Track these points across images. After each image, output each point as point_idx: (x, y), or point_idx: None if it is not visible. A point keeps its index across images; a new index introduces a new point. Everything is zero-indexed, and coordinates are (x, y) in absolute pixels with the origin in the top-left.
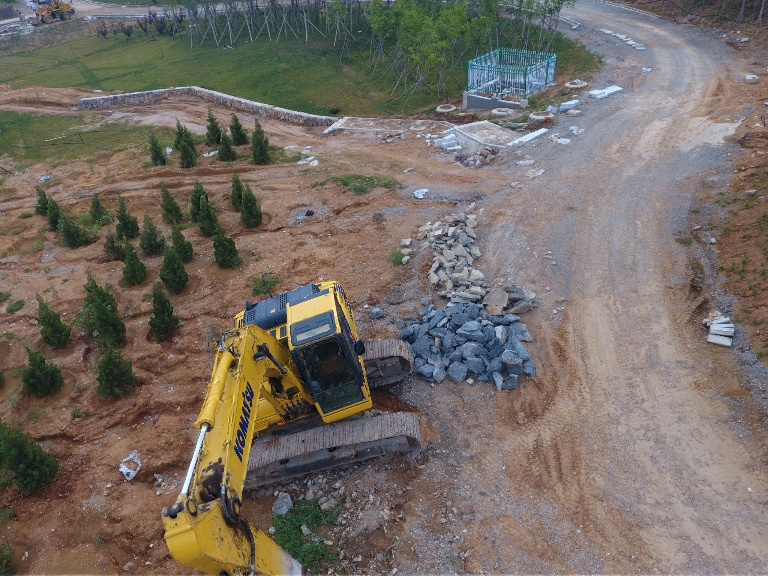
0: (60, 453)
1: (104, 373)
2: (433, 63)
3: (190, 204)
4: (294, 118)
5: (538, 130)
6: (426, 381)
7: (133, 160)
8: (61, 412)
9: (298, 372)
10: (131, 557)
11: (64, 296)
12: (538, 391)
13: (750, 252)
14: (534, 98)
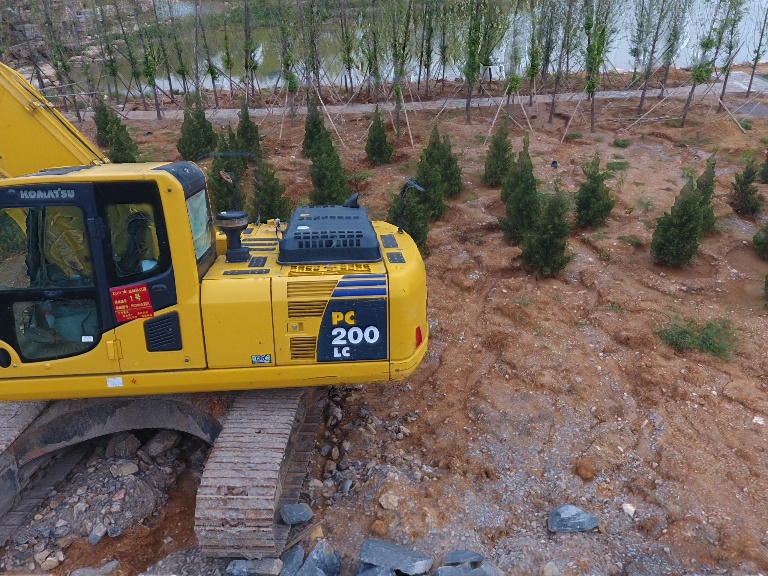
0: None
1: None
2: None
3: None
4: None
5: None
6: None
7: None
8: None
9: None
10: None
11: (628, 193)
12: None
13: None
14: None
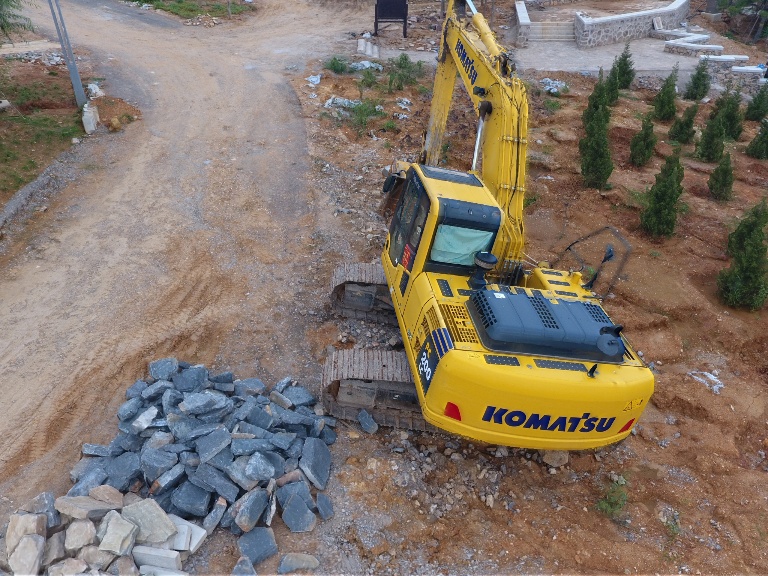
0: None
1: None
2: None
3: None
4: None
5: None
6: None
7: None
8: None
9: None
10: None
11: None
12: None
13: None
14: None
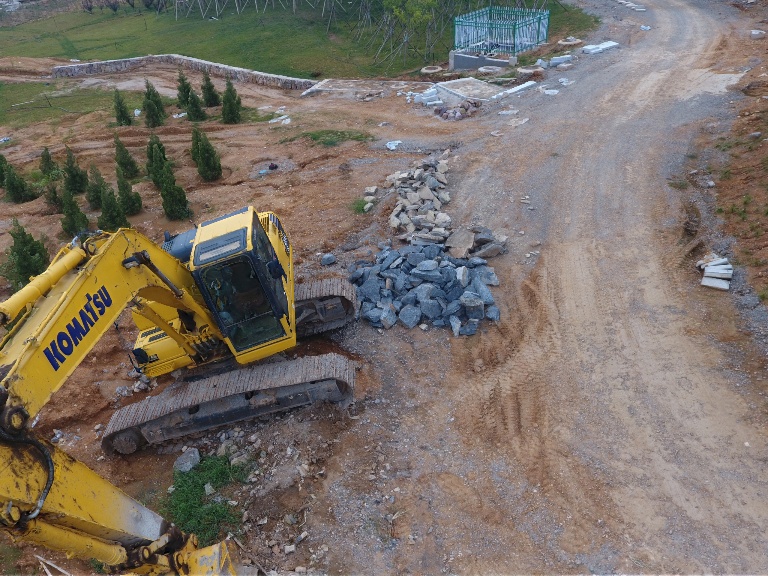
0: None
1: None
2: (418, 22)
3: None
4: (272, 81)
5: (525, 82)
6: (373, 327)
7: (99, 122)
8: None
9: (201, 298)
10: None
11: None
12: (501, 337)
13: (753, 193)
14: (524, 57)
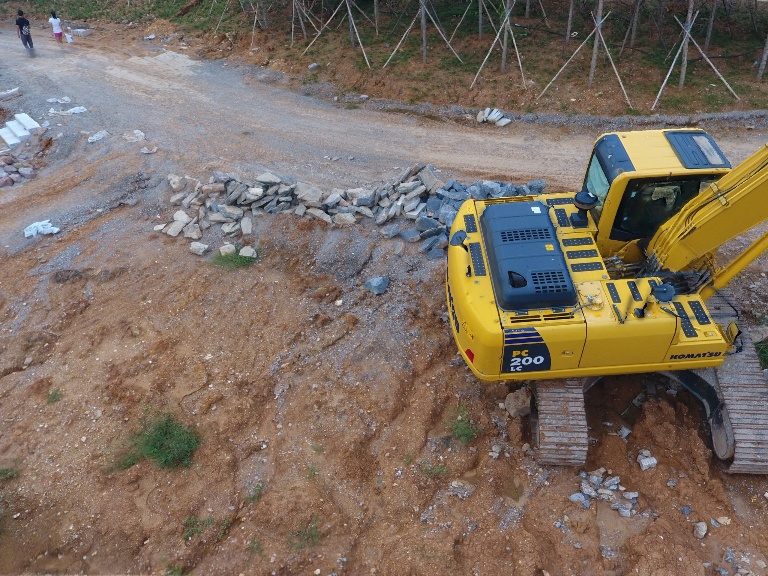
0: None
1: None
2: None
3: None
4: None
5: (17, 117)
6: None
7: None
8: None
9: None
10: None
11: None
12: None
13: (403, 85)
14: None
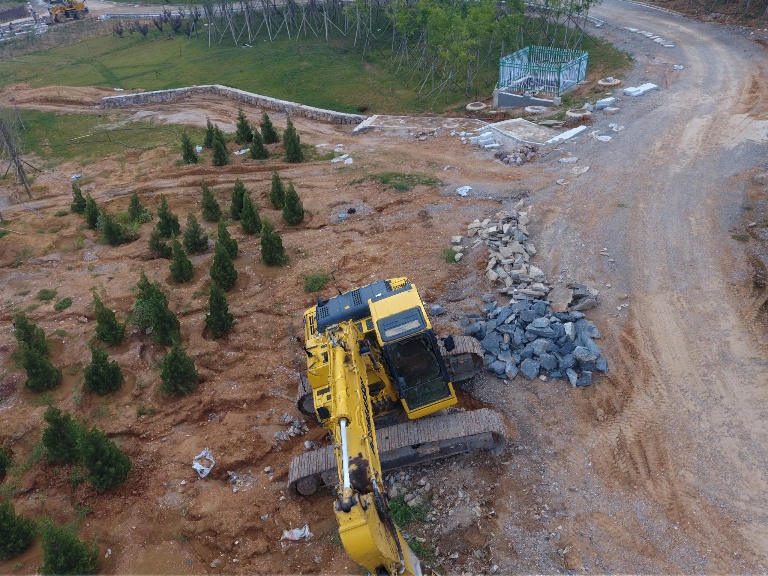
0: (130, 450)
1: (169, 370)
2: (463, 61)
3: (228, 202)
4: (322, 116)
5: (577, 127)
6: (498, 378)
7: (163, 158)
8: (125, 409)
9: (387, 368)
10: (217, 554)
11: (112, 294)
12: (613, 388)
13: None
14: (566, 96)
